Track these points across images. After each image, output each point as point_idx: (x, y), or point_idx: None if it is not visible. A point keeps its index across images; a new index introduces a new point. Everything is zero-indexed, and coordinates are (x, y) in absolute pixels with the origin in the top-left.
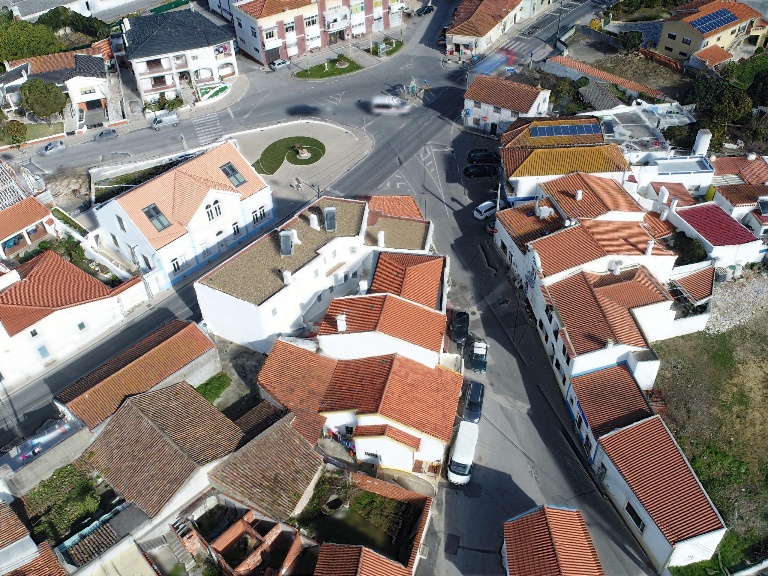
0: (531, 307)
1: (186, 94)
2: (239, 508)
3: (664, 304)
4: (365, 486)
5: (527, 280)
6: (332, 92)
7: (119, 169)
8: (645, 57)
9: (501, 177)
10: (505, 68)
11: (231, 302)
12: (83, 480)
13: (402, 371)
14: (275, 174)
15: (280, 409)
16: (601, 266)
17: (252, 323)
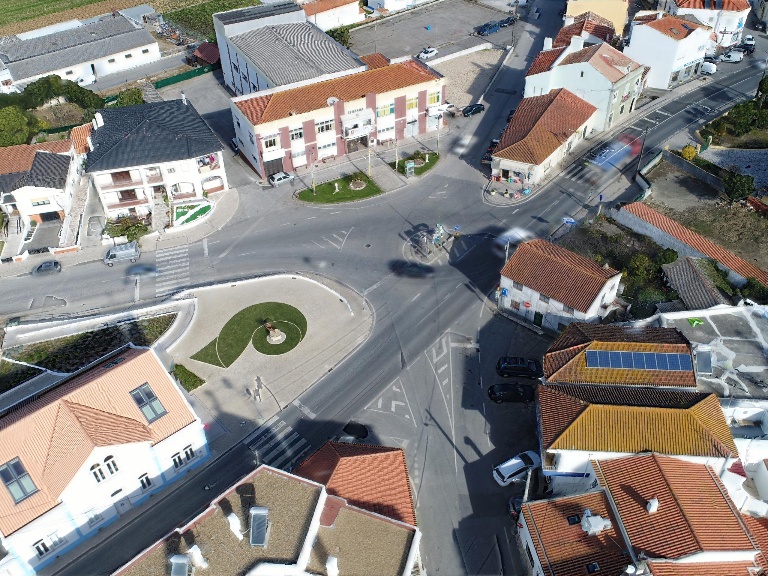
0: None
1: (158, 213)
2: None
3: None
4: None
5: None
6: (337, 228)
7: (40, 331)
8: (755, 210)
9: (537, 426)
10: (563, 219)
11: None
12: None
13: None
14: (231, 367)
15: None
16: None
17: None
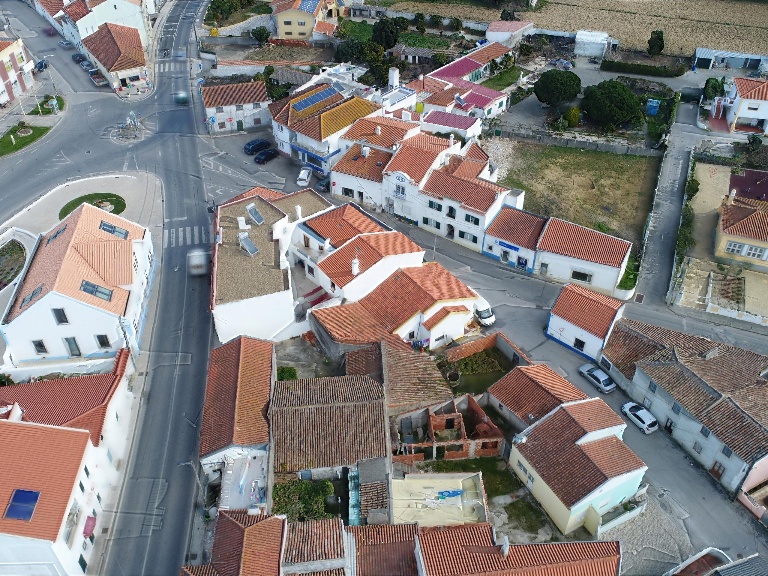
0: (405, 217)
1: None
2: (415, 417)
3: (487, 167)
4: (455, 358)
5: (396, 198)
6: (49, 156)
7: None
8: (276, 45)
9: (301, 148)
10: (196, 81)
11: (259, 303)
12: (299, 485)
13: (414, 275)
14: None
15: (367, 348)
16: (438, 163)
17: (281, 312)
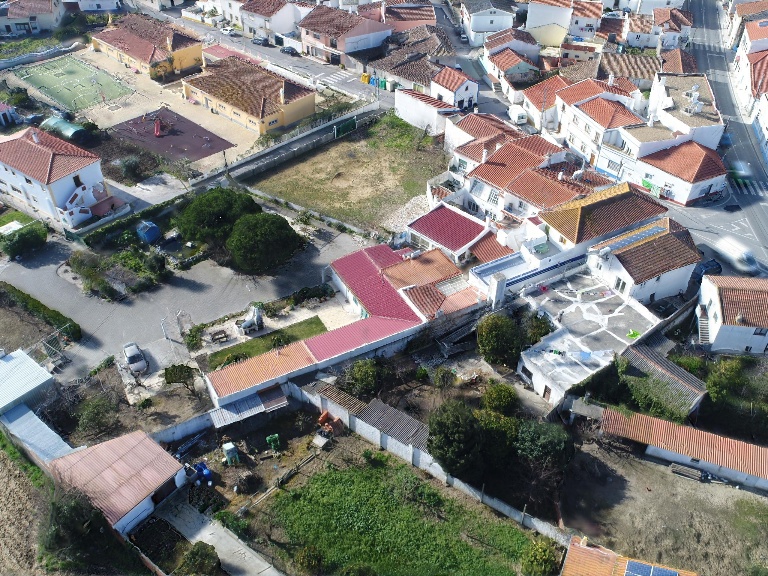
0: None
1: None
2: None
3: None
4: None
5: None
6: None
7: None
8: None
9: None
10: None
11: None
12: None
13: None
14: None
15: None
16: None
17: None
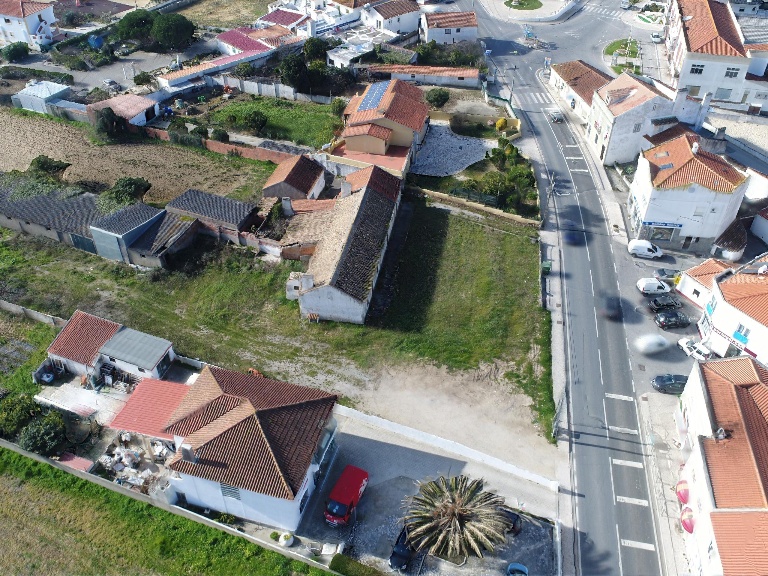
0: None
1: None
2: None
3: None
4: None
5: None
6: (585, 36)
7: None
8: None
9: None
10: None
11: None
12: None
13: None
14: None
15: None
16: None
17: None
